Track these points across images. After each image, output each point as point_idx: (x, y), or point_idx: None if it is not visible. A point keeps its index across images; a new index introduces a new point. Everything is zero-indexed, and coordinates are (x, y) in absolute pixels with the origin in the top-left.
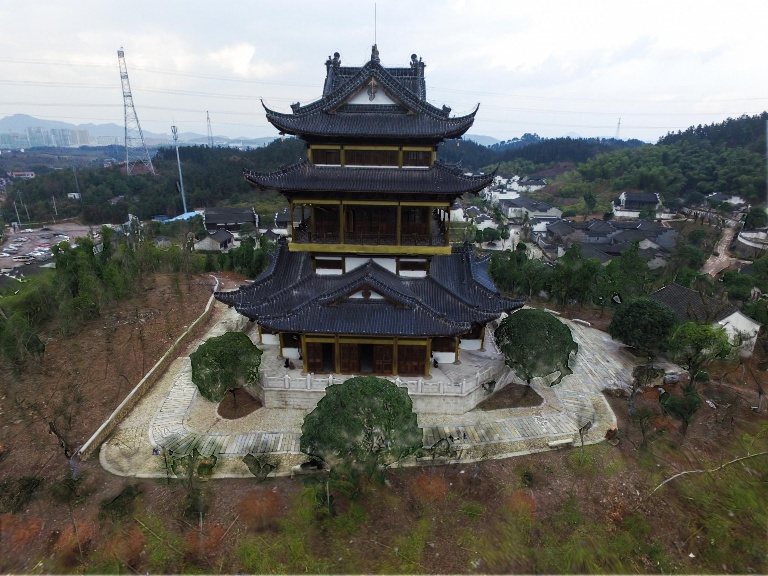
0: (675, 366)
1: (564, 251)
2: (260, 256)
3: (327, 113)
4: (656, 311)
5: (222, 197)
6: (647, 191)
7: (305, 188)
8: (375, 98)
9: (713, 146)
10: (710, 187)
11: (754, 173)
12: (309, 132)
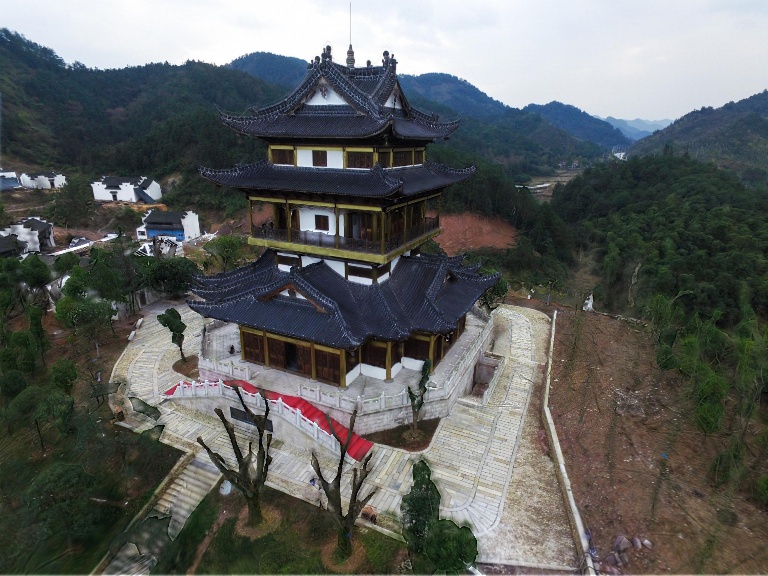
0: None
1: None
2: None
3: None
4: None
5: None
6: None
7: None
8: None
9: None
10: None
11: None
12: None
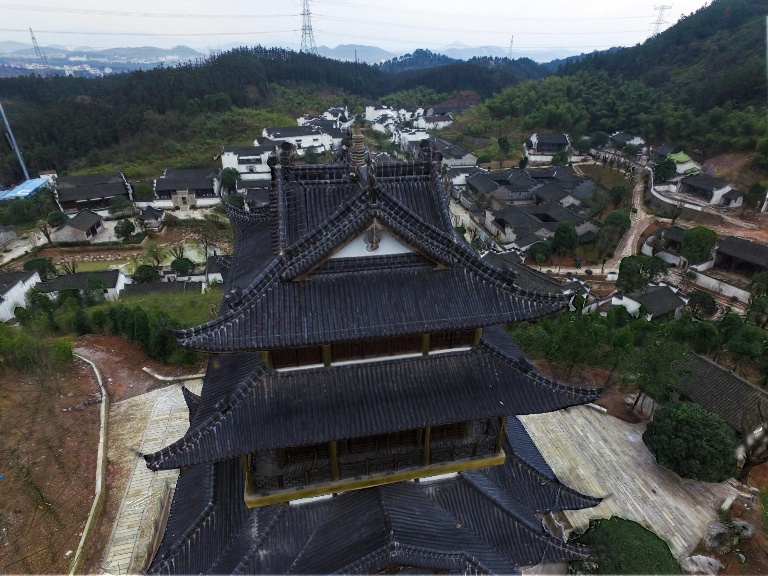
0: (722, 482)
1: (493, 216)
2: (160, 336)
3: (290, 281)
4: (713, 434)
5: (75, 154)
6: (556, 131)
7: (274, 448)
8: None
9: (610, 78)
10: (612, 124)
11: (651, 111)
12: (269, 347)
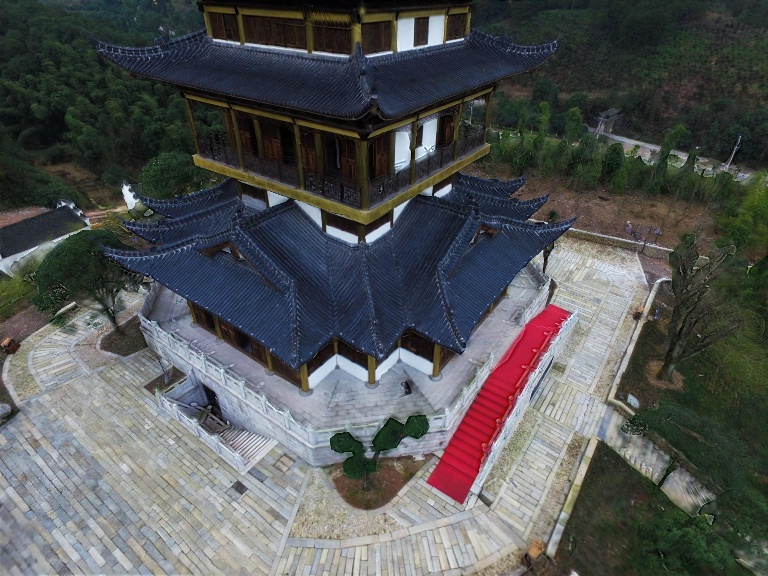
0: None
1: None
2: None
3: None
4: None
5: None
6: None
7: None
8: None
9: None
10: None
11: None
12: None
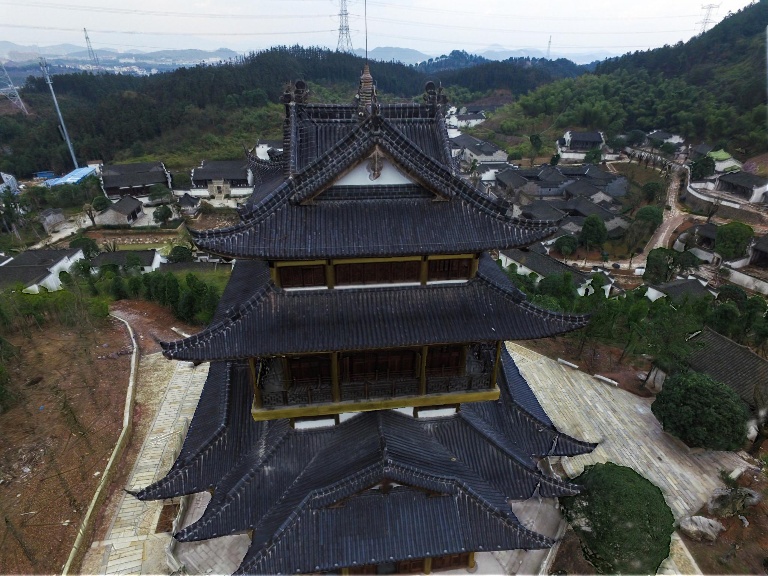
0: (732, 455)
1: (521, 210)
2: (189, 298)
3: (298, 204)
4: (722, 402)
5: (121, 146)
6: (590, 129)
7: (277, 353)
8: (379, 176)
9: (650, 76)
10: (649, 123)
11: (692, 109)
12: (275, 257)
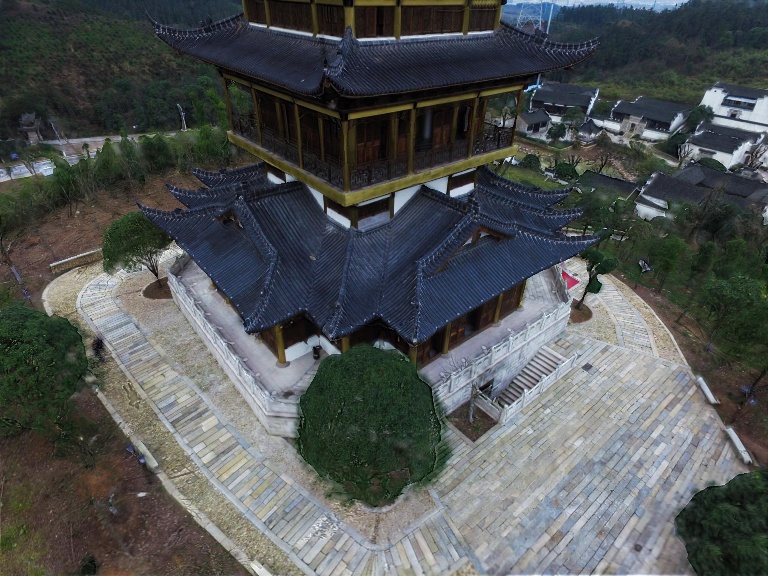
0: None
1: None
2: None
3: None
4: None
5: (583, 72)
6: None
7: (200, 56)
8: None
9: None
10: None
11: None
12: None
